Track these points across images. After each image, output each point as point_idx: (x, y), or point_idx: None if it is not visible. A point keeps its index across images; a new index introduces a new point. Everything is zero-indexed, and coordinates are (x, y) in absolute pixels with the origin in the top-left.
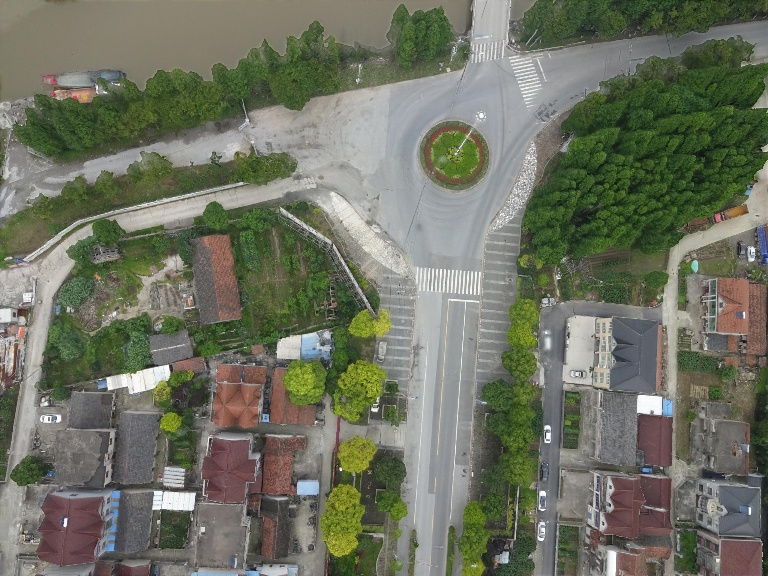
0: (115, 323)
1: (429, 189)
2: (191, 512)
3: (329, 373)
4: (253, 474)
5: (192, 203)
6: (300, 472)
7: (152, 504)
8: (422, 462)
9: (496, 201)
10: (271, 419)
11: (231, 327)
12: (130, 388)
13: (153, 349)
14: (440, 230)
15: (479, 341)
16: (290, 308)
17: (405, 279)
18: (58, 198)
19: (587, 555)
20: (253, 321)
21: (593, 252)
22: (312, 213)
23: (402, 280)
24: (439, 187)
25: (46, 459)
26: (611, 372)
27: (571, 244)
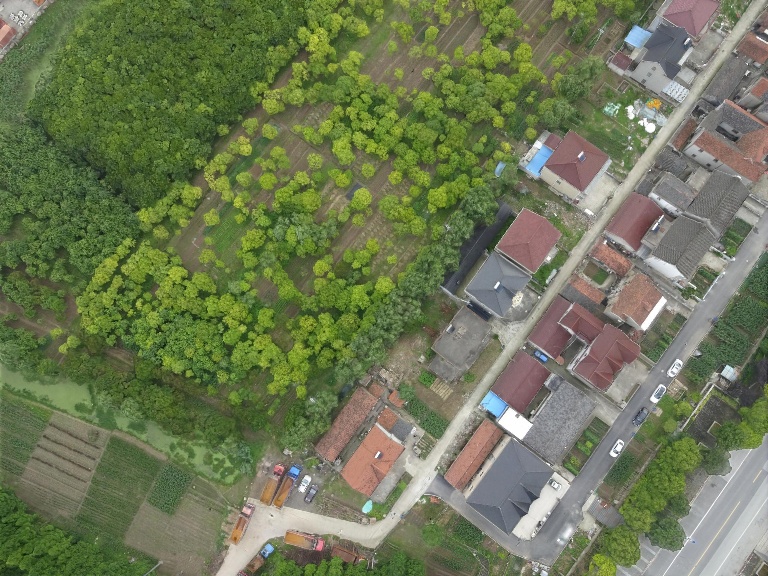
0: None
1: None
2: None
3: None
4: None
5: None
6: None
7: None
8: (759, 505)
9: None
10: None
11: None
12: None
13: None
14: None
15: None
16: None
17: None
18: None
19: None
20: None
21: None
22: None
23: None
24: None
25: None
26: None
27: None
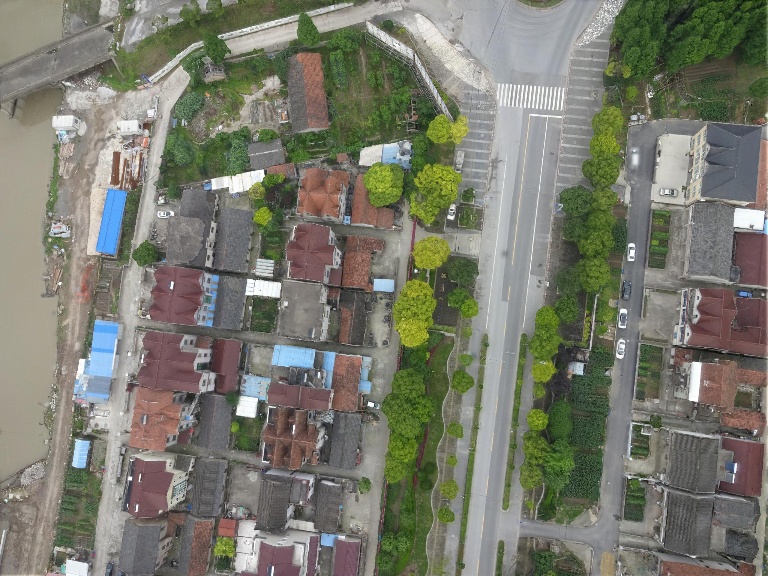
0: (220, 134)
1: (513, 8)
2: (279, 301)
3: (407, 177)
4: (331, 255)
5: (289, 28)
6: (378, 273)
7: (245, 290)
8: (496, 270)
9: (584, 17)
10: (352, 220)
11: (319, 139)
12: (230, 188)
13: (251, 153)
14: (523, 47)
15: (560, 155)
16: (373, 121)
17: (486, 95)
18: (177, 24)
19: (671, 377)
20: (340, 135)
21: (688, 60)
22: (397, 33)
23: (483, 96)
24: (524, 5)
25: (161, 249)
26: (703, 179)
27: (664, 55)
